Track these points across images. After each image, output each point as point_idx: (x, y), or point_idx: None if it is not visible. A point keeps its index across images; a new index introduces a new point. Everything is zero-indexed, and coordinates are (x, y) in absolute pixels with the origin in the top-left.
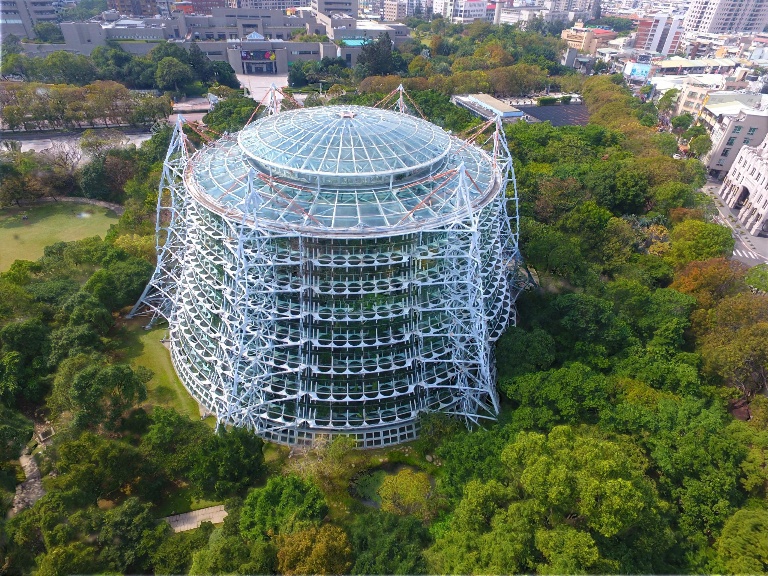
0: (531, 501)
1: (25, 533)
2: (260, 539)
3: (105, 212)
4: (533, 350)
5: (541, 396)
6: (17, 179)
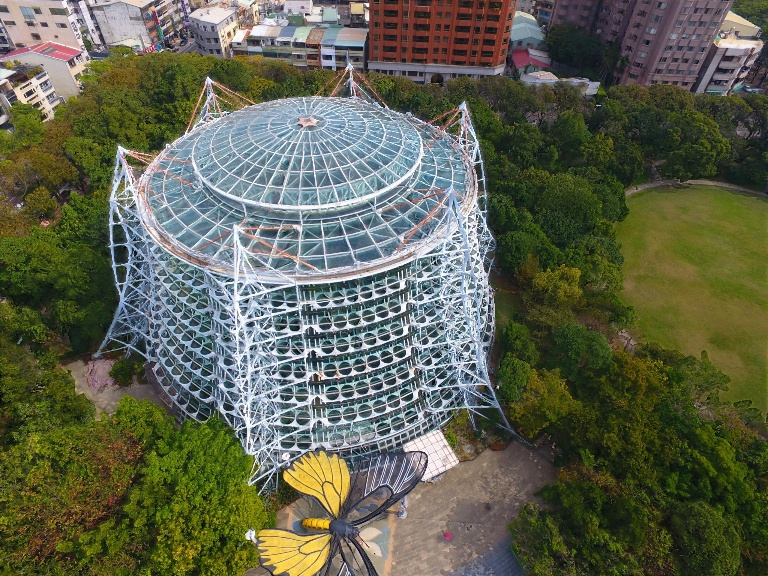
0: None
1: None
2: None
3: None
4: None
5: None
6: None
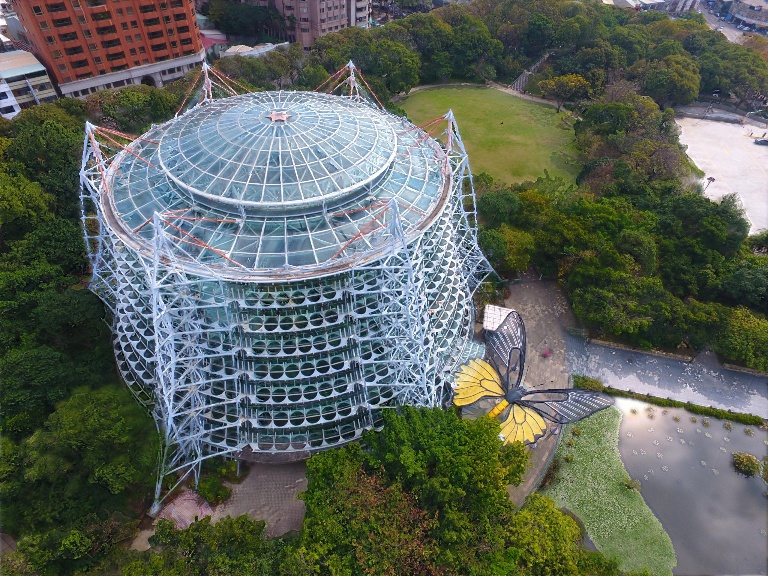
0: None
1: None
2: None
3: None
4: None
5: (31, 273)
6: (603, 140)
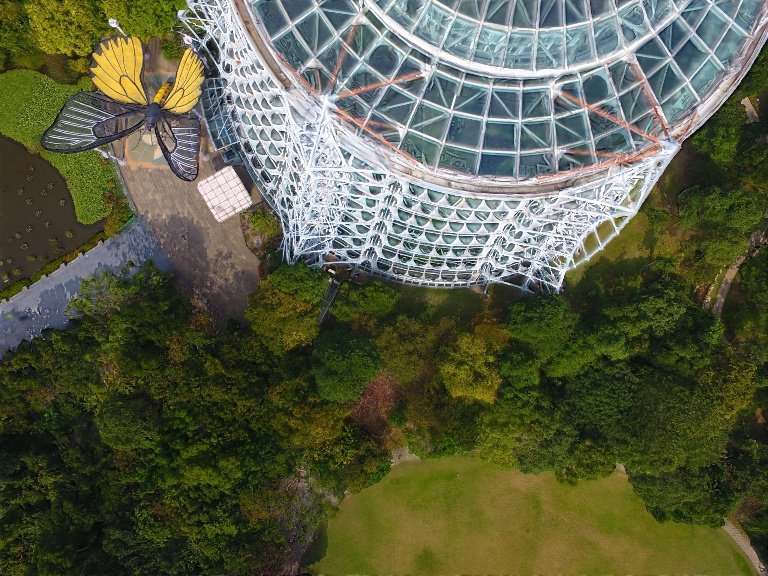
0: None
1: None
2: None
3: (310, 568)
4: None
5: None
6: None
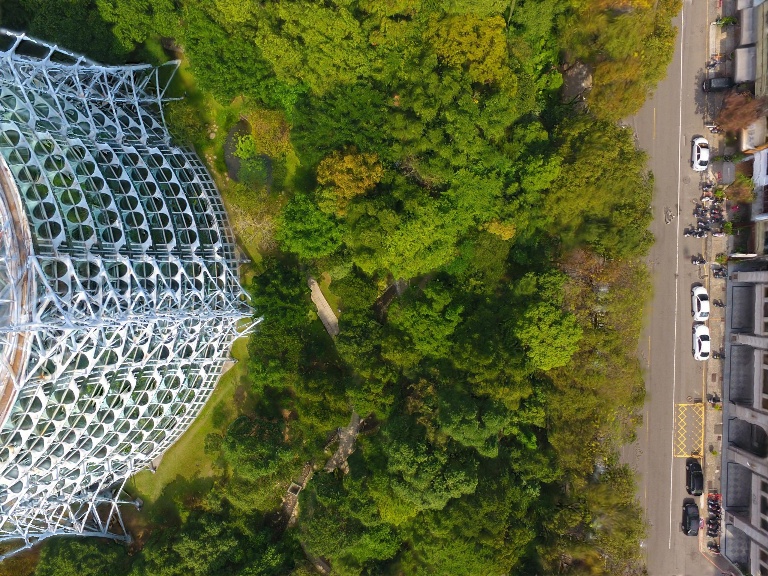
0: (266, 7)
1: (388, 396)
2: (342, 226)
3: None
4: (69, 8)
5: (139, 1)
6: None
